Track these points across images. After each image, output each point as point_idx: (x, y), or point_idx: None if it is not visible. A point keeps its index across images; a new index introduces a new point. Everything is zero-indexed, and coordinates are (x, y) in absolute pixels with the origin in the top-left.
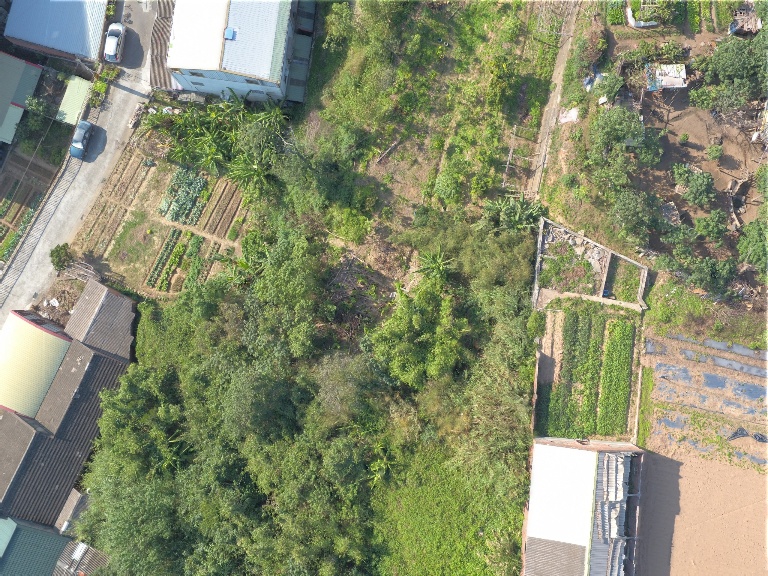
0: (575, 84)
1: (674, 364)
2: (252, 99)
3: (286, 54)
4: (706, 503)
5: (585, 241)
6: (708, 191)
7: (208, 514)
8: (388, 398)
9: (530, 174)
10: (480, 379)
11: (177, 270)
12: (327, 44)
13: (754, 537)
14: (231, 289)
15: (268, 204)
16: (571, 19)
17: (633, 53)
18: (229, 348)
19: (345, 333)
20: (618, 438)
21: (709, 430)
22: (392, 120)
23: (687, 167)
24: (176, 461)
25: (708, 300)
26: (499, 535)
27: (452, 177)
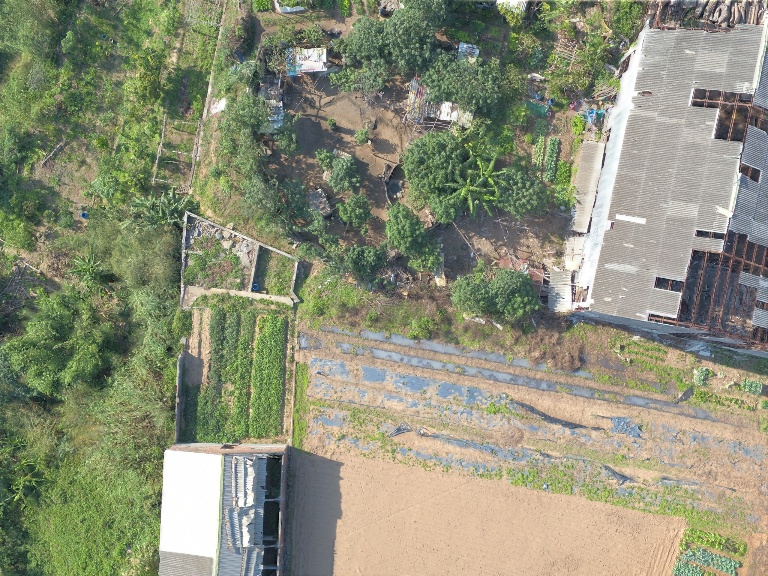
0: (224, 74)
1: (330, 359)
2: None
3: None
4: (370, 505)
5: (233, 234)
6: (351, 176)
7: None
8: (25, 410)
9: None
10: (122, 385)
11: None
12: None
13: (423, 539)
14: None
15: None
16: None
17: (274, 39)
18: None
19: None
20: (273, 440)
21: (370, 427)
22: (56, 121)
23: (334, 153)
24: None
25: (364, 290)
26: (144, 551)
27: (111, 176)
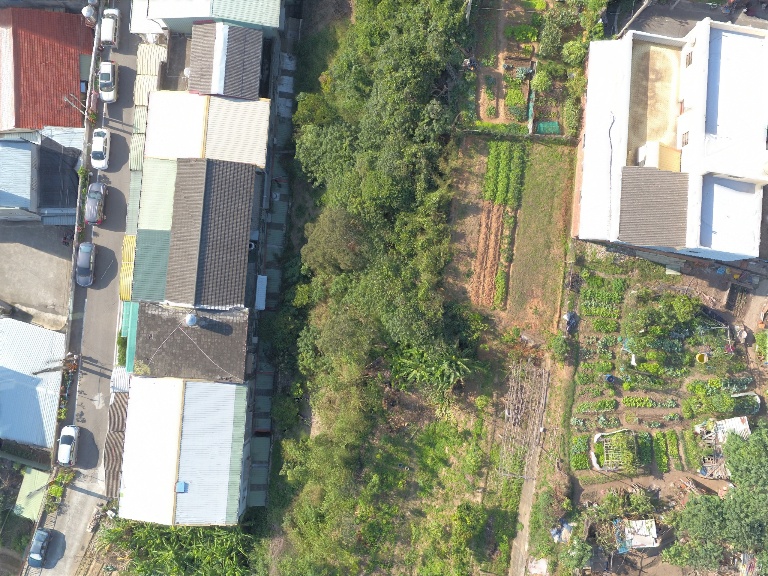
0: (542, 532)
1: None
2: None
3: (243, 479)
4: None
5: None
6: None
7: None
8: None
9: None
10: None
11: None
12: (284, 471)
13: None
14: None
15: None
16: (534, 457)
17: (600, 509)
18: None
19: None
20: None
21: None
22: (356, 552)
23: None
24: None
25: None
26: None
27: None
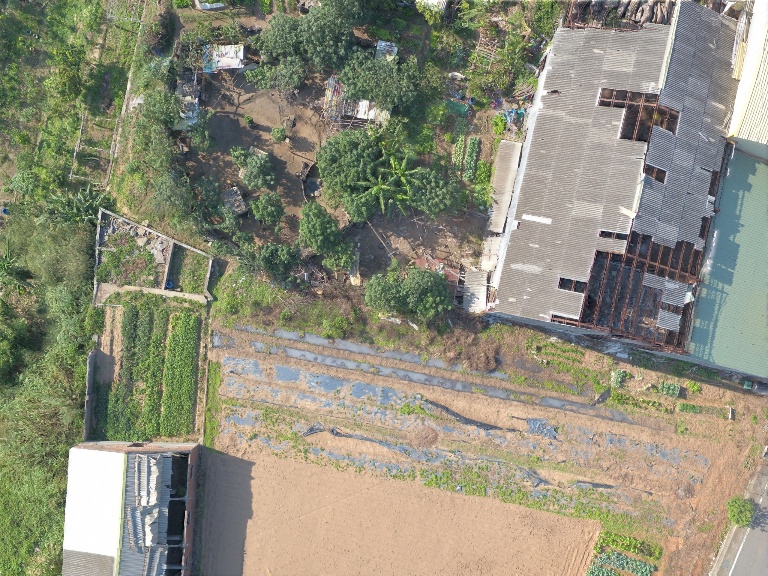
0: None
1: (243, 357)
2: None
3: None
4: (281, 505)
5: (147, 231)
6: (266, 174)
7: None
8: None
9: None
10: (33, 382)
11: None
12: None
13: (334, 539)
14: None
15: None
16: None
17: (191, 35)
18: None
19: None
20: (185, 439)
21: (283, 426)
22: None
23: (251, 150)
24: None
25: (278, 288)
26: (51, 550)
27: (30, 172)
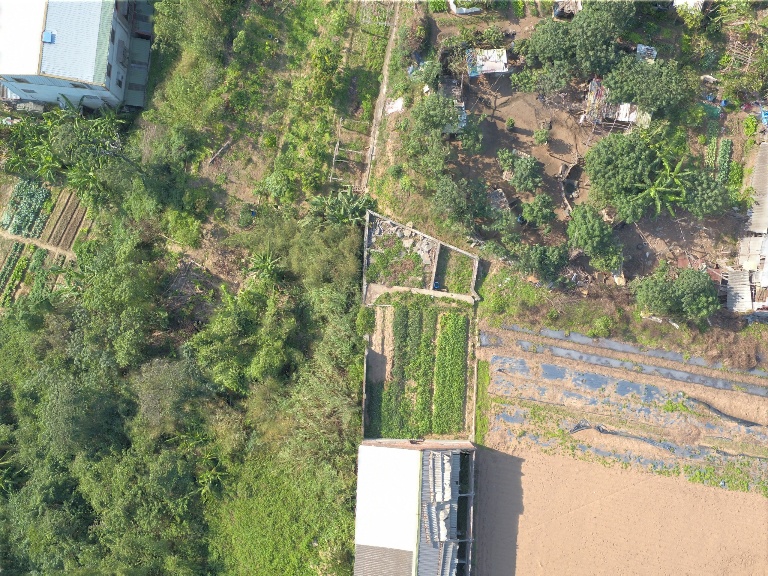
0: (400, 74)
1: (511, 356)
2: (93, 106)
3: (116, 57)
4: (551, 501)
5: (413, 233)
6: (534, 176)
7: (36, 538)
8: (213, 405)
9: (364, 168)
10: (308, 381)
11: (21, 285)
12: (156, 45)
13: (603, 534)
14: (66, 301)
15: (111, 212)
16: (395, 9)
17: (453, 39)
18: (55, 361)
19: (182, 341)
20: (456, 436)
21: (550, 424)
22: (224, 119)
23: (514, 153)
24: (8, 484)
25: (543, 288)
26: (333, 545)
27: (283, 174)
